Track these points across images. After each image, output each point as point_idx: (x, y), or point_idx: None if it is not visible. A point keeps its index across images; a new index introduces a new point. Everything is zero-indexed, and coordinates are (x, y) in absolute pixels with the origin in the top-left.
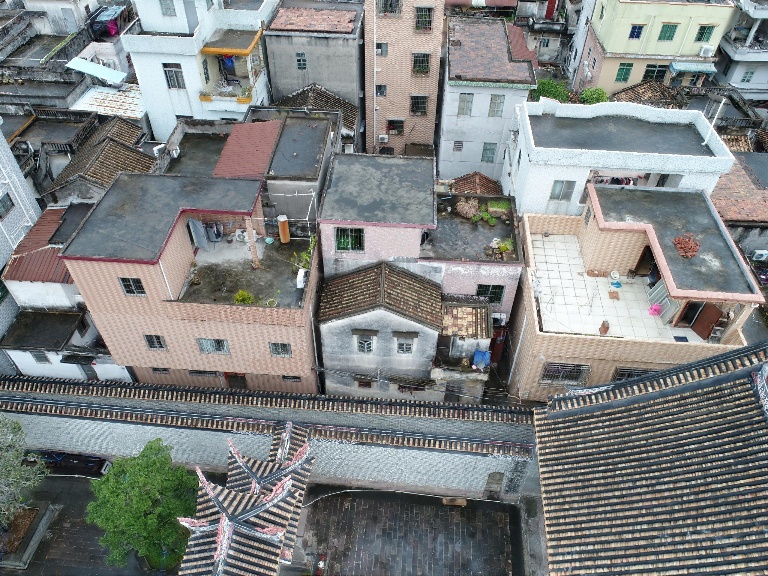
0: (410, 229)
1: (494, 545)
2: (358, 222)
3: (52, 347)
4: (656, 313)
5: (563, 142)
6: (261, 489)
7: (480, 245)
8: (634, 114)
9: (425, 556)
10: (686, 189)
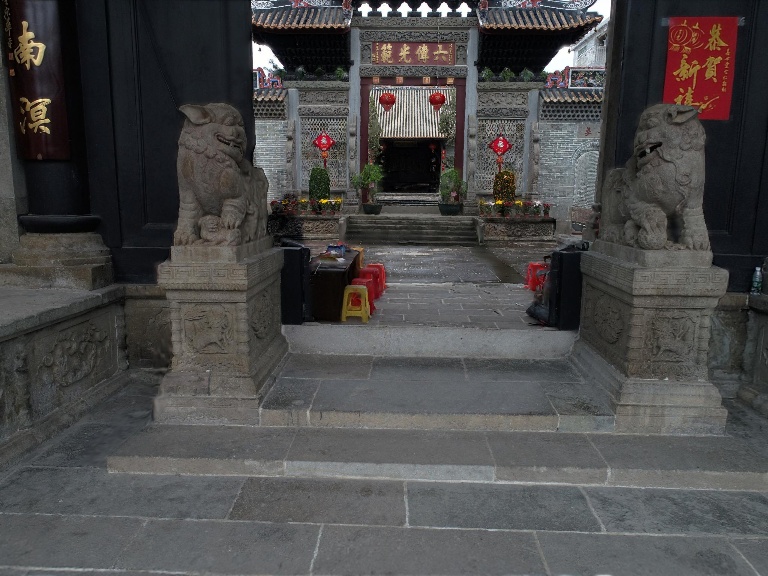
0: None
1: None
2: None
3: None
4: None
5: None
6: (537, 6)
7: None
8: None
9: None
10: None
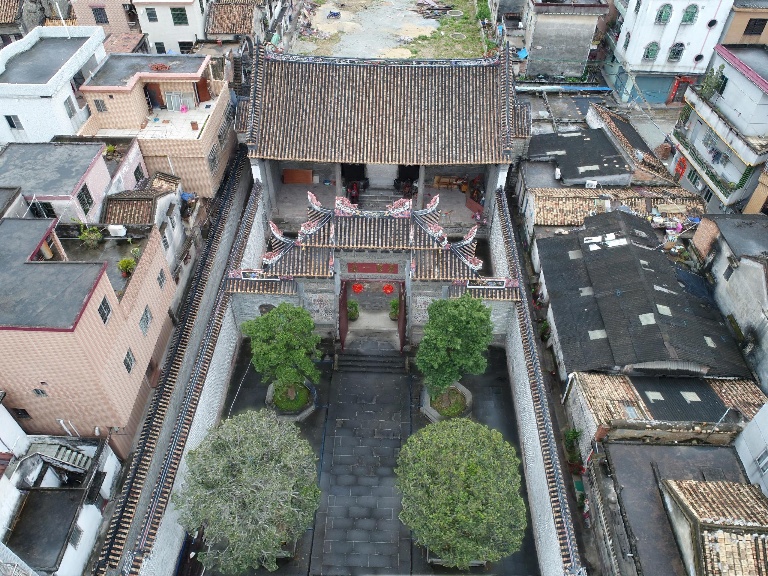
0: (98, 159)
1: None
2: (83, 177)
3: (78, 502)
4: (186, 110)
5: (34, 82)
6: None
7: None
8: (15, 52)
9: None
10: (106, 58)
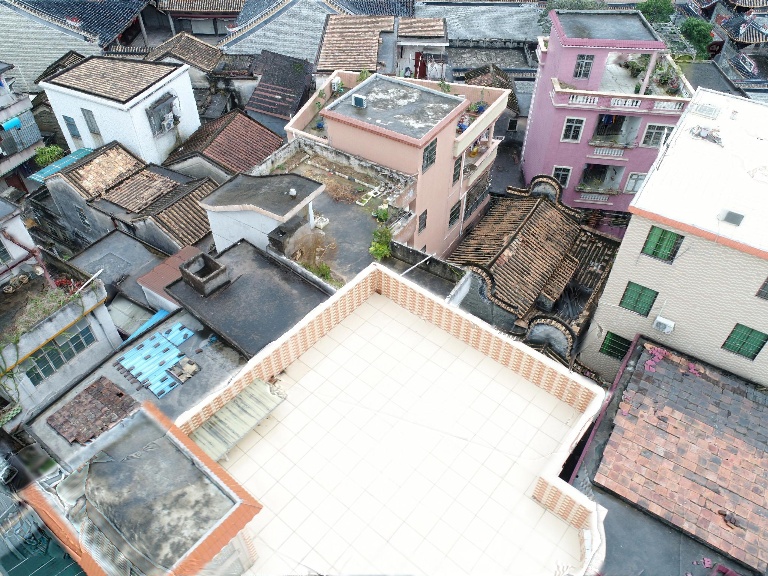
0: None
1: (764, 63)
2: None
3: None
4: None
5: None
6: None
7: None
8: None
9: None
10: None
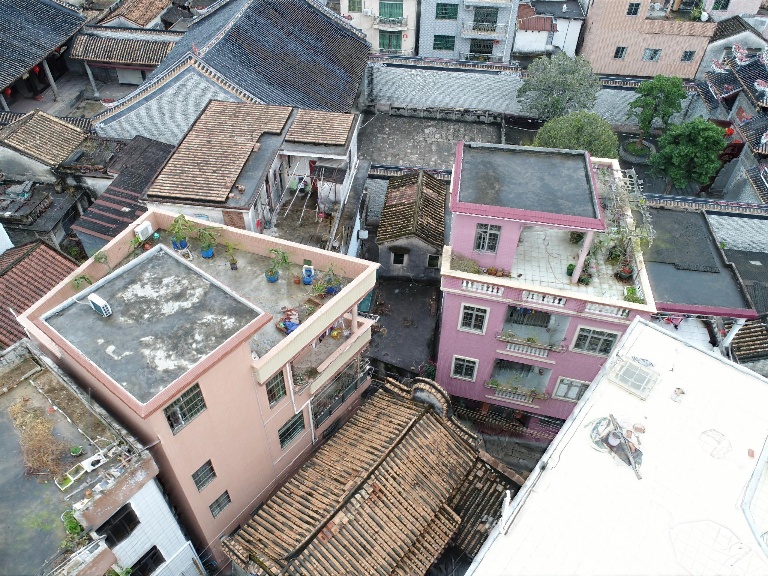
0: None
1: None
2: None
3: None
4: None
5: None
6: None
7: None
8: None
9: (767, 161)
10: None
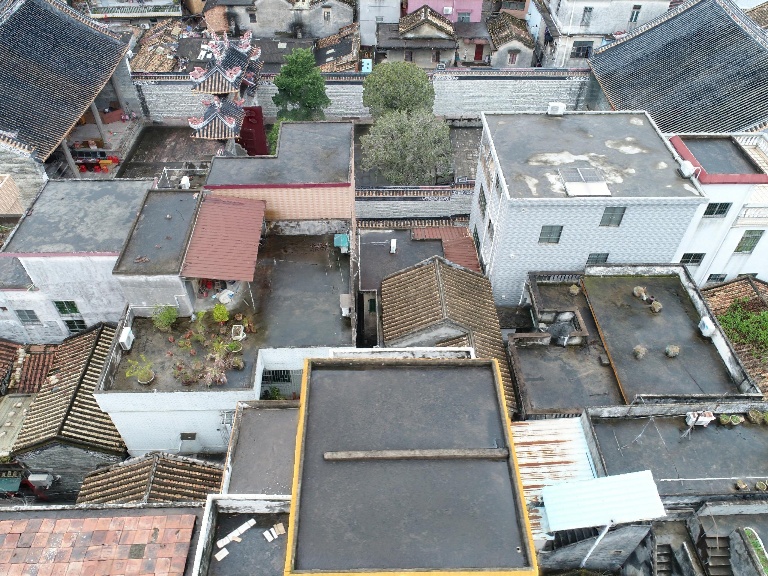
0: None
1: None
2: None
3: None
4: None
5: None
6: None
7: (3, 256)
8: None
9: None
10: None
